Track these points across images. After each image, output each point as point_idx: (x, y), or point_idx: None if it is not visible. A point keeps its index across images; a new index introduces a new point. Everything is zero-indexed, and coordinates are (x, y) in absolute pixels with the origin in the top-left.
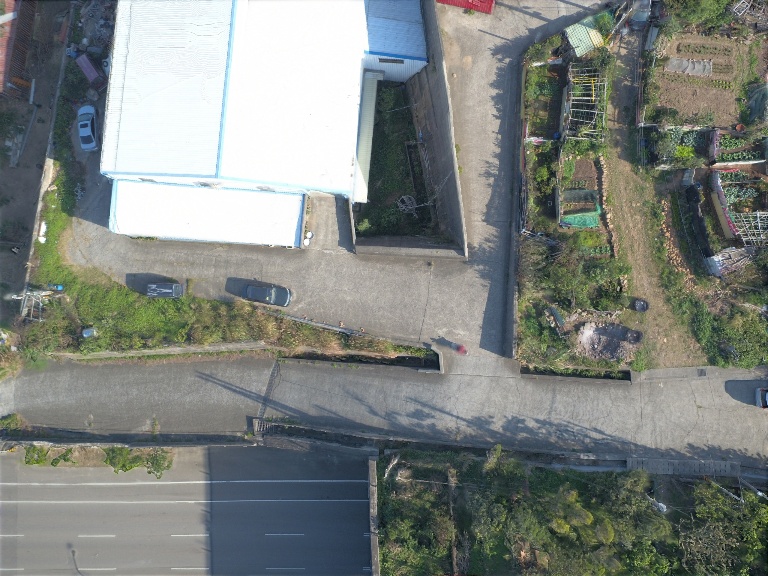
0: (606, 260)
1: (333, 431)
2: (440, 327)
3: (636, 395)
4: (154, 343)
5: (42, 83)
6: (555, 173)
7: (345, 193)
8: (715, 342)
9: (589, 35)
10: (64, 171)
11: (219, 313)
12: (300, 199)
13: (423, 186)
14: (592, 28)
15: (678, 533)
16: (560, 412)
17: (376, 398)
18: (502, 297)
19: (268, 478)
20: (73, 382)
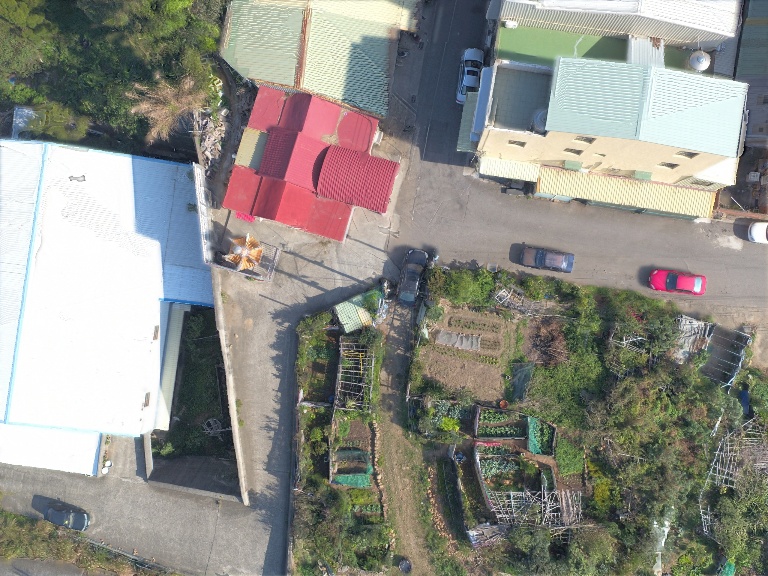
0: (376, 518)
1: None
2: (225, 564)
3: None
4: None
5: None
6: (327, 436)
7: (134, 436)
8: None
9: (358, 313)
10: None
11: (22, 531)
12: None
13: None
14: (361, 307)
15: None
16: None
17: None
18: (282, 541)
19: None
20: None
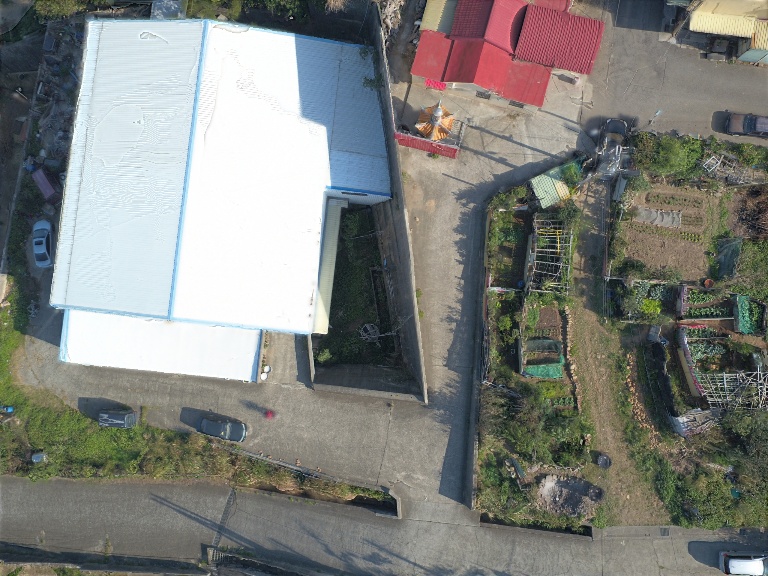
0: (569, 412)
1: (288, 569)
2: (399, 470)
3: (597, 552)
4: (105, 472)
5: (1, 183)
6: (518, 323)
7: (303, 333)
8: (679, 502)
9: (555, 187)
10: (18, 287)
11: (172, 446)
12: (258, 333)
13: (387, 313)
14: (558, 180)
15: None
16: (519, 565)
17: (333, 537)
18: (463, 443)
19: None
20: (25, 495)
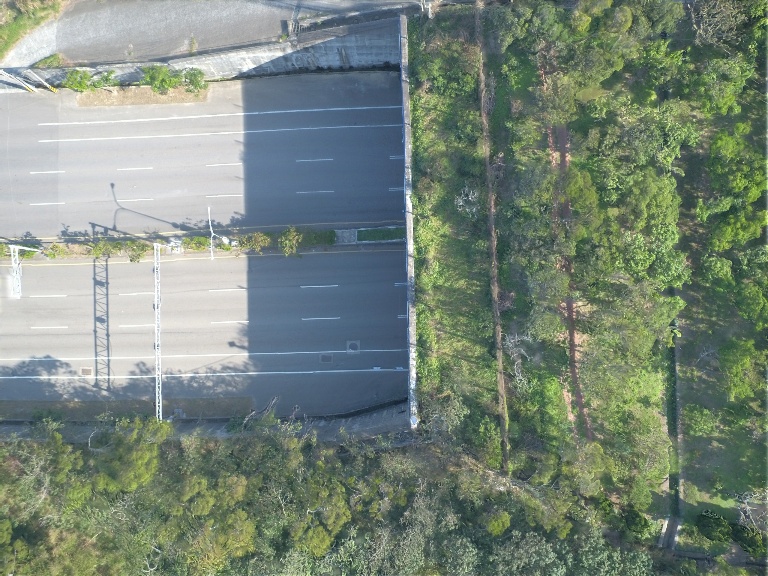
0: None
1: (365, 9)
2: None
3: None
4: None
5: None
6: None
7: None
8: None
9: None
10: None
11: None
12: None
13: None
14: None
15: (691, 20)
16: None
17: None
18: None
19: (299, 108)
20: (113, 17)
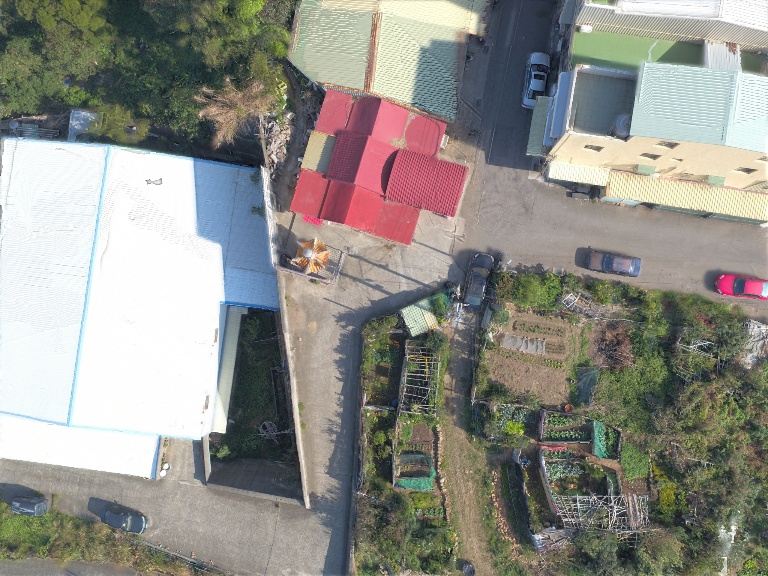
0: (439, 522)
1: None
2: (284, 567)
3: None
4: (18, 555)
5: None
6: (391, 439)
7: (195, 439)
8: None
9: (424, 317)
10: None
11: (79, 534)
12: None
13: (286, 411)
14: (427, 310)
15: None
16: None
17: None
18: (343, 545)
19: None
20: None
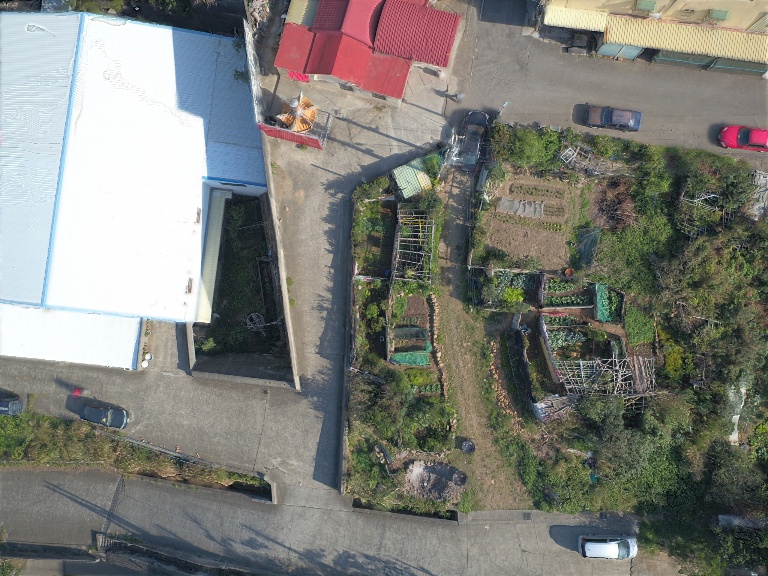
0: (436, 398)
1: (170, 555)
2: (274, 456)
3: (463, 536)
4: None
5: None
6: (385, 311)
7: (178, 321)
8: (540, 487)
9: (417, 177)
10: None
11: (56, 432)
12: (138, 321)
13: (273, 303)
14: (420, 170)
15: None
16: (389, 549)
17: (213, 523)
18: (335, 429)
19: None
20: None
